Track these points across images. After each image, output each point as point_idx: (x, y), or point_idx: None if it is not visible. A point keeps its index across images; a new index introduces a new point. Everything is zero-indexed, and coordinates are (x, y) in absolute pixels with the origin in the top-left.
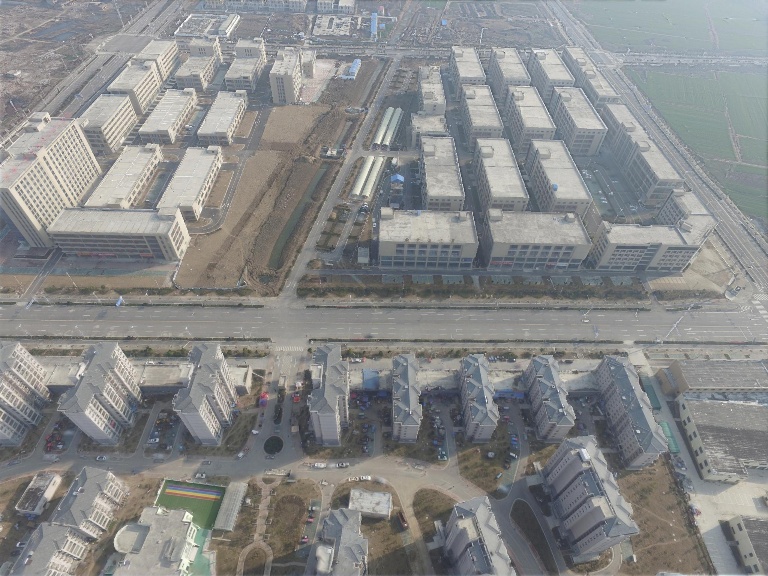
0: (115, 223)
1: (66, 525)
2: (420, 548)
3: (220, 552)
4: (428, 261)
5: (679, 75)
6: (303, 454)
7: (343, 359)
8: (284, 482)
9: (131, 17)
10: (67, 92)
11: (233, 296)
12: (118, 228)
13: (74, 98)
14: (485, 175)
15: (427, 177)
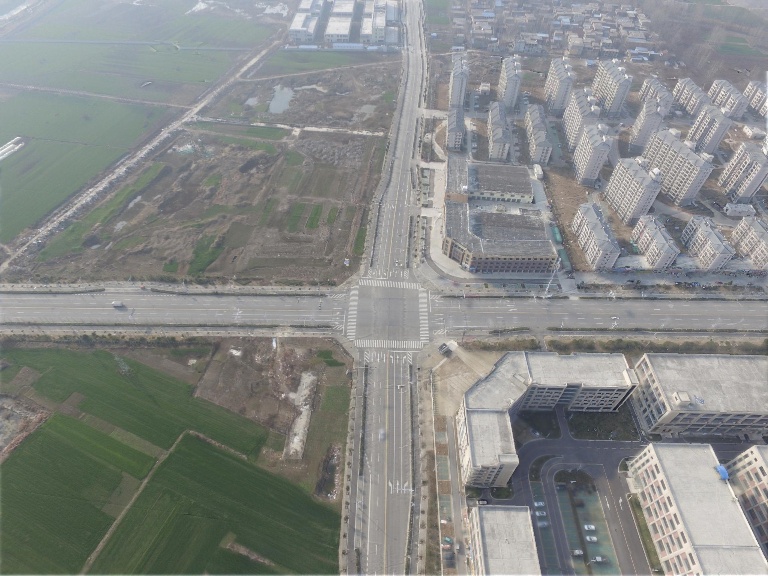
0: None
1: None
2: (700, 199)
3: None
4: None
5: None
6: None
7: None
8: None
9: None
10: None
11: None
12: None
13: None
14: None
15: None
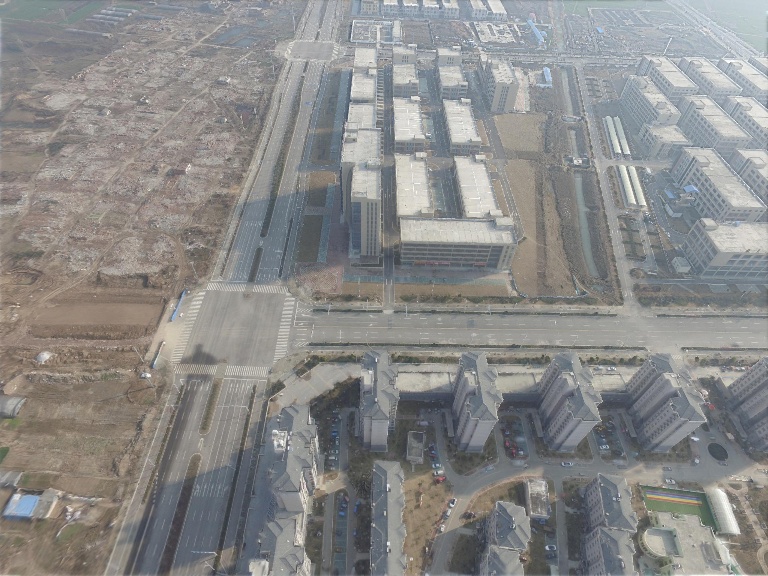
0: (458, 233)
1: (624, 530)
2: None
3: (737, 555)
4: (751, 271)
5: None
6: (751, 460)
7: (727, 367)
8: (752, 488)
9: (303, 23)
10: (288, 99)
11: (582, 305)
12: (465, 238)
13: (299, 105)
14: (767, 186)
15: (717, 188)
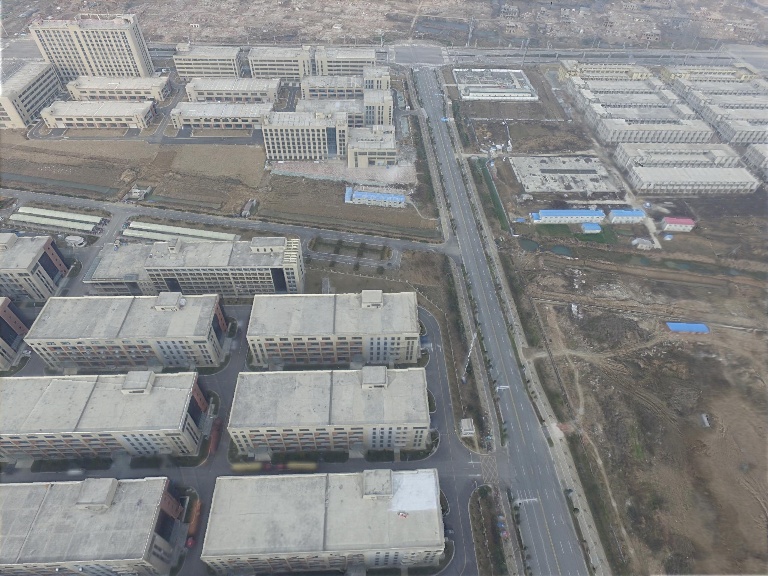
0: (16, 81)
1: None
2: None
3: None
4: None
5: None
6: None
7: None
8: None
9: None
10: None
11: None
12: (8, 83)
13: None
14: None
15: None
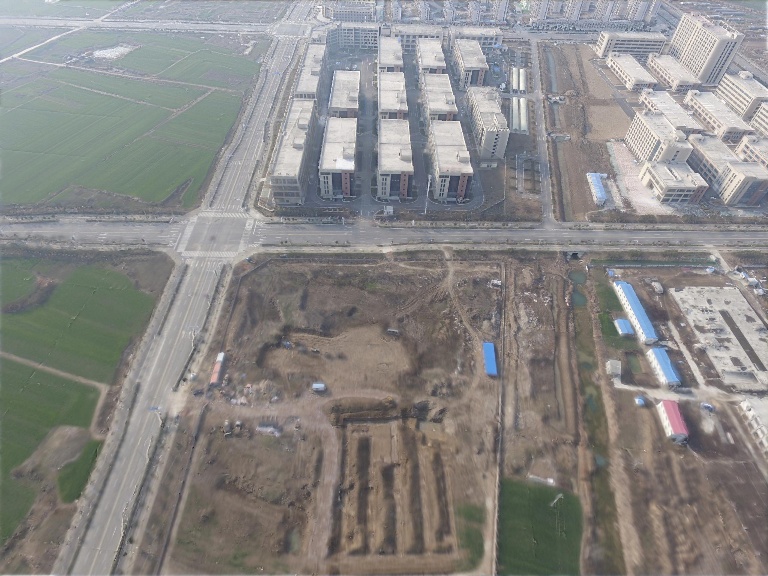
0: (633, 35)
1: None
2: None
3: None
4: None
5: (118, 194)
6: None
7: None
8: None
9: None
10: None
11: None
12: None
13: None
14: None
15: None
